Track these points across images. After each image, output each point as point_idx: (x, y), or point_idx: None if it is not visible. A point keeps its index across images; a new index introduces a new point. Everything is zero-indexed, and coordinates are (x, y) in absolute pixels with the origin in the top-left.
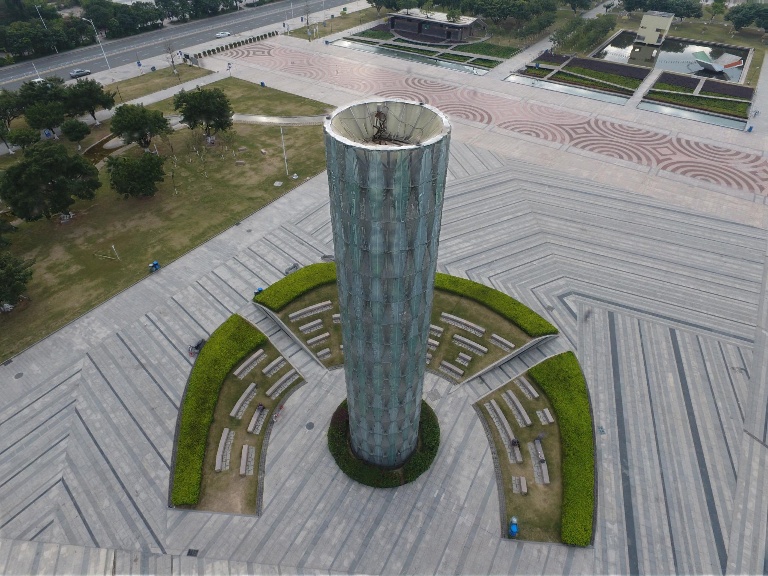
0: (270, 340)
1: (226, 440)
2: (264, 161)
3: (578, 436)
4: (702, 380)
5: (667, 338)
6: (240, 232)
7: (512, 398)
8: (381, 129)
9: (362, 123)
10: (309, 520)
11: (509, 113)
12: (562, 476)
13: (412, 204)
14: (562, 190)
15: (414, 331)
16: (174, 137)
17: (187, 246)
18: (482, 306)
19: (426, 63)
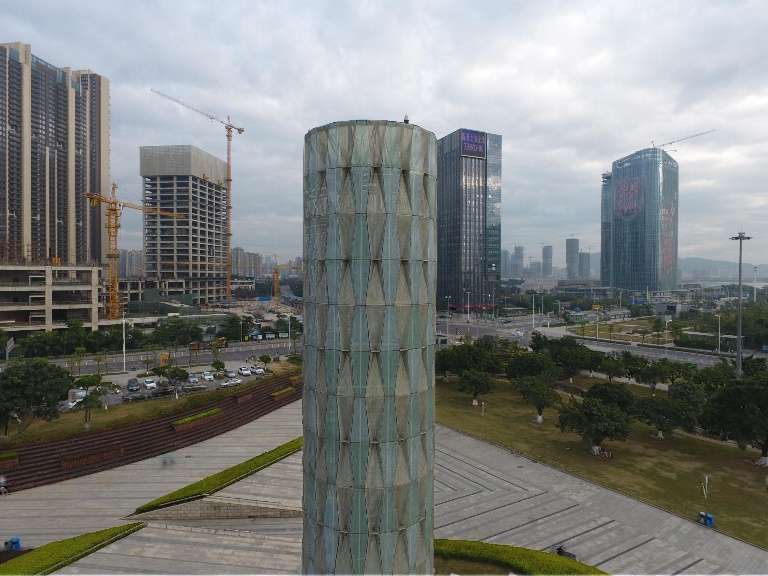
0: None
1: None
2: None
3: None
4: None
5: None
6: None
7: None
8: None
9: None
10: None
11: None
12: None
13: None
14: None
15: None
16: None
17: None
18: None
19: None
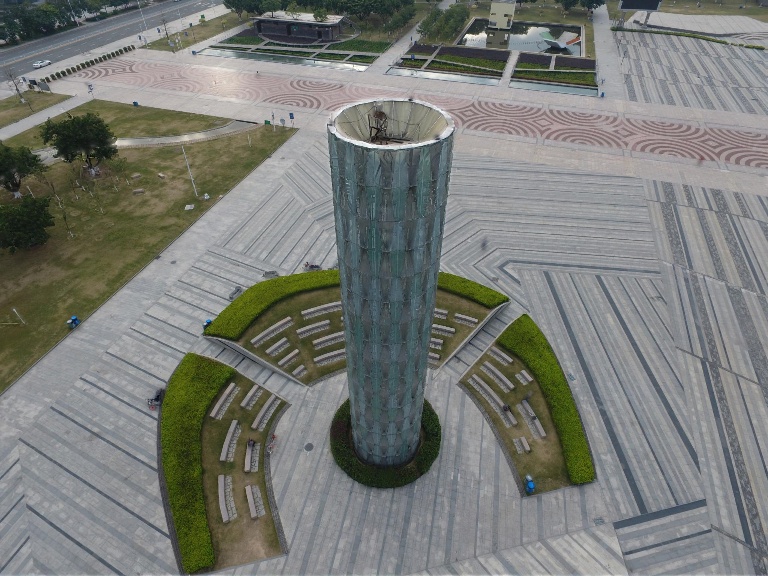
0: (238, 371)
1: (224, 487)
2: (165, 186)
3: (556, 387)
4: (633, 314)
5: (596, 284)
6: (163, 265)
7: (491, 368)
8: (381, 129)
9: (356, 126)
10: (340, 541)
11: None
12: (555, 426)
13: (430, 198)
14: (470, 170)
15: (426, 323)
16: (47, 174)
17: (105, 292)
18: (438, 290)
19: (305, 64)
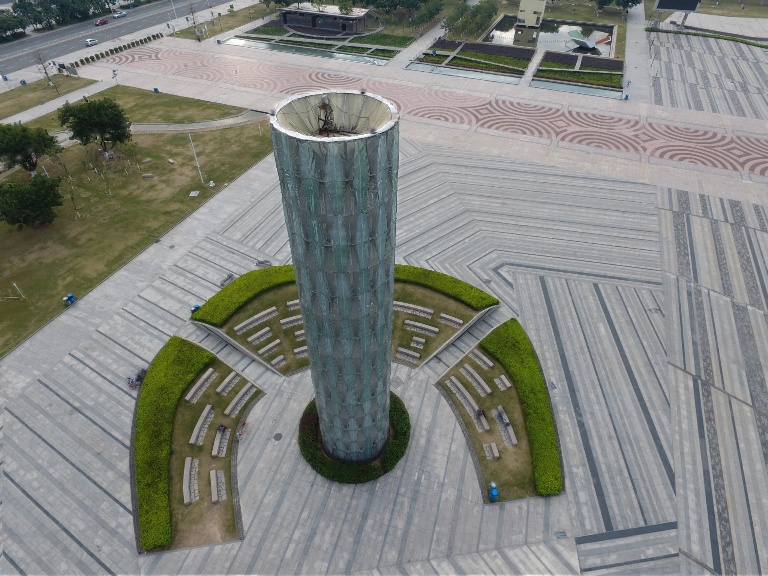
0: (218, 357)
1: (190, 470)
2: (174, 171)
3: (535, 395)
4: (627, 325)
5: (592, 292)
6: (162, 249)
7: (470, 371)
8: (328, 121)
9: (305, 117)
10: (295, 531)
11: (416, 100)
12: (527, 434)
13: (371, 193)
14: (478, 169)
15: (381, 321)
16: (64, 156)
17: (104, 272)
18: (426, 289)
19: (326, 57)
